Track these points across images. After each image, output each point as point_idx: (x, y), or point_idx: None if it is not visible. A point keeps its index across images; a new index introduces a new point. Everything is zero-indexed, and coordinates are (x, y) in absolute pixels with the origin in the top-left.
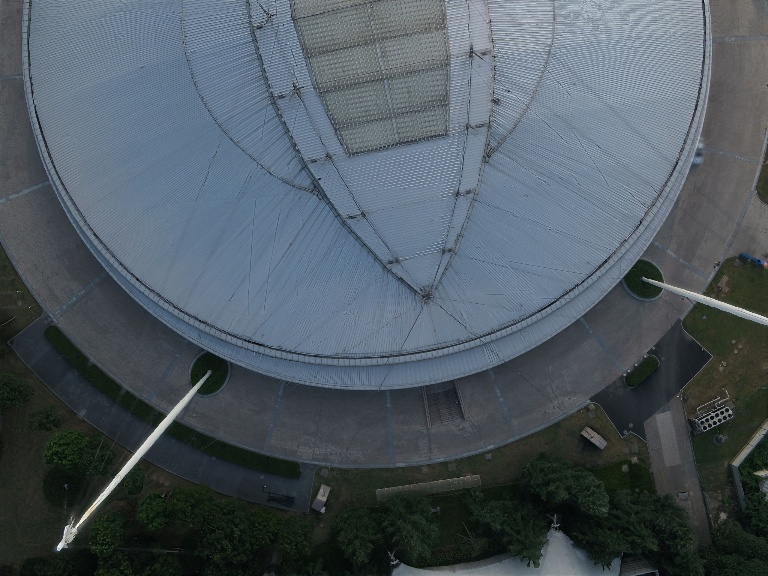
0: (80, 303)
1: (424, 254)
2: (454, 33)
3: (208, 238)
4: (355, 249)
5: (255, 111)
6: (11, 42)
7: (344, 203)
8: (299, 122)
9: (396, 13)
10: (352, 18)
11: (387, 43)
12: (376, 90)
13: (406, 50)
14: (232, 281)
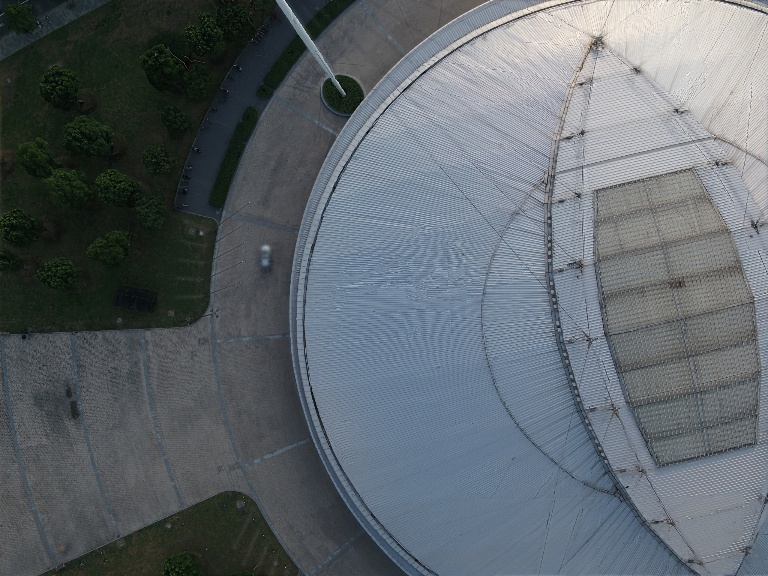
0: (336, 562)
1: (724, 553)
2: (765, 345)
3: (501, 532)
4: (649, 543)
5: (560, 418)
6: (264, 302)
7: (651, 510)
8: (610, 434)
9: (709, 328)
10: (666, 334)
11: (700, 358)
12: (689, 404)
13: (719, 364)
14: (520, 570)
